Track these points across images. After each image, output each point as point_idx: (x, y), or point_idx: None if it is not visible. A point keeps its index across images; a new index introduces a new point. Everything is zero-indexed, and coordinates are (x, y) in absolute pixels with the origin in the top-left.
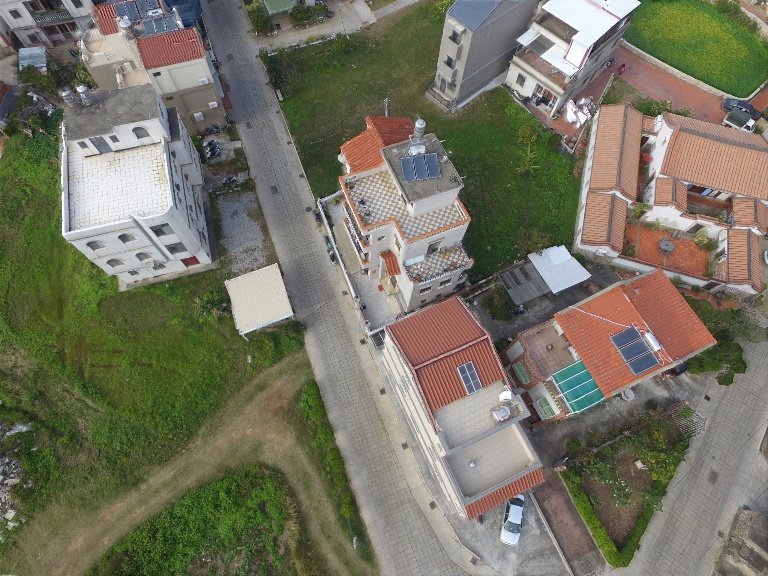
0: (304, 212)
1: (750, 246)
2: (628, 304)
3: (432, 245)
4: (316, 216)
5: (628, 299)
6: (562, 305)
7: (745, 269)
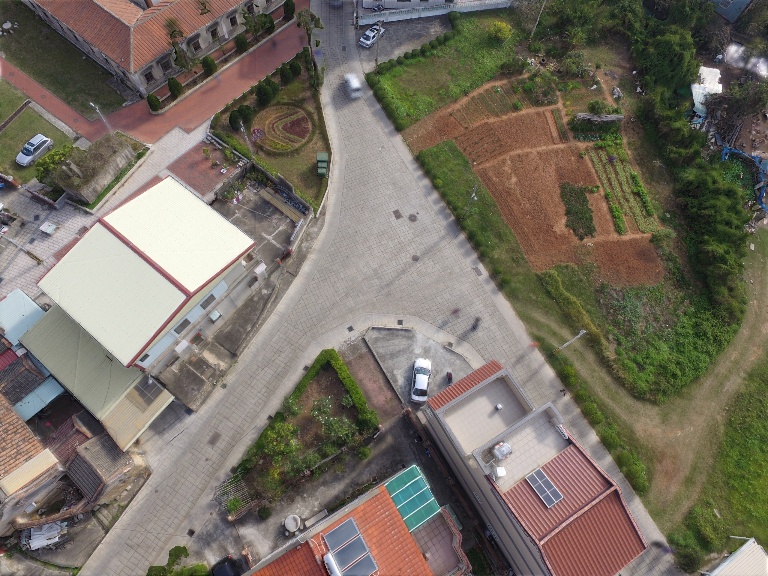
0: None
1: None
2: None
3: None
4: None
5: None
6: None
7: None
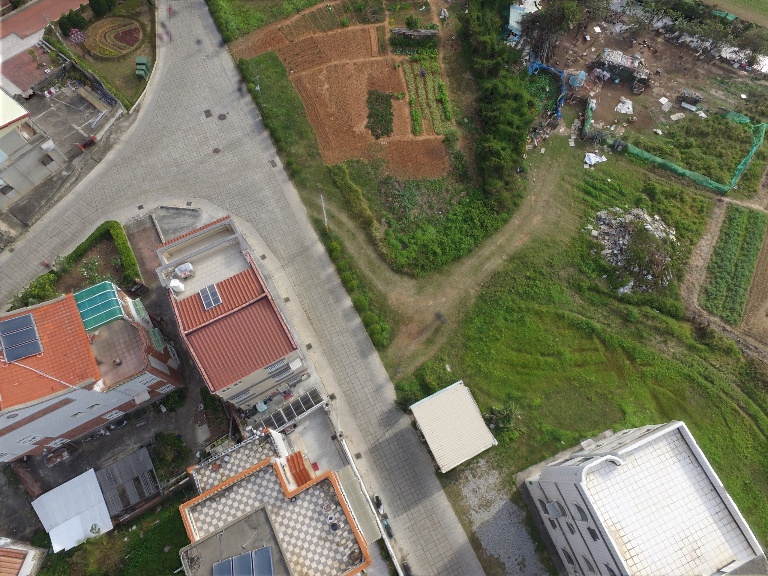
0: None
1: None
2: (2, 388)
3: None
4: (411, 574)
5: None
6: (87, 465)
7: None
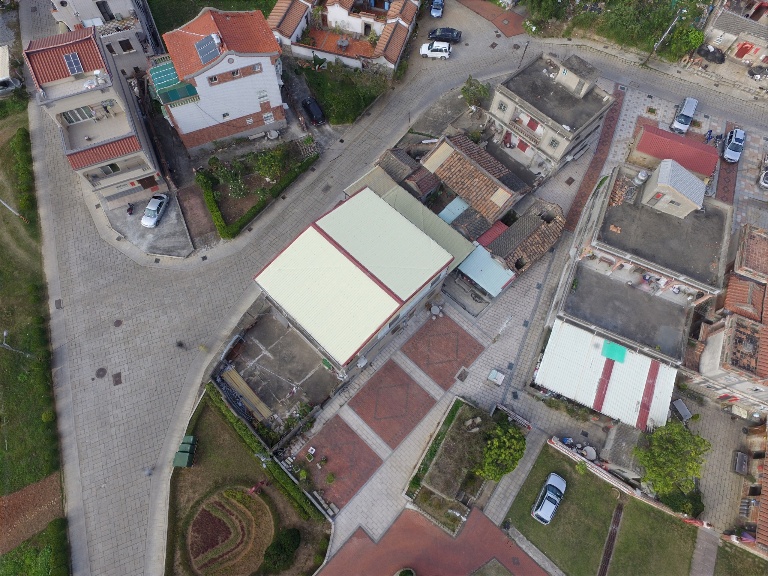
0: (54, 24)
1: (395, 33)
2: (212, 21)
3: (102, 7)
4: None
5: (212, 18)
6: None
7: (384, 47)
